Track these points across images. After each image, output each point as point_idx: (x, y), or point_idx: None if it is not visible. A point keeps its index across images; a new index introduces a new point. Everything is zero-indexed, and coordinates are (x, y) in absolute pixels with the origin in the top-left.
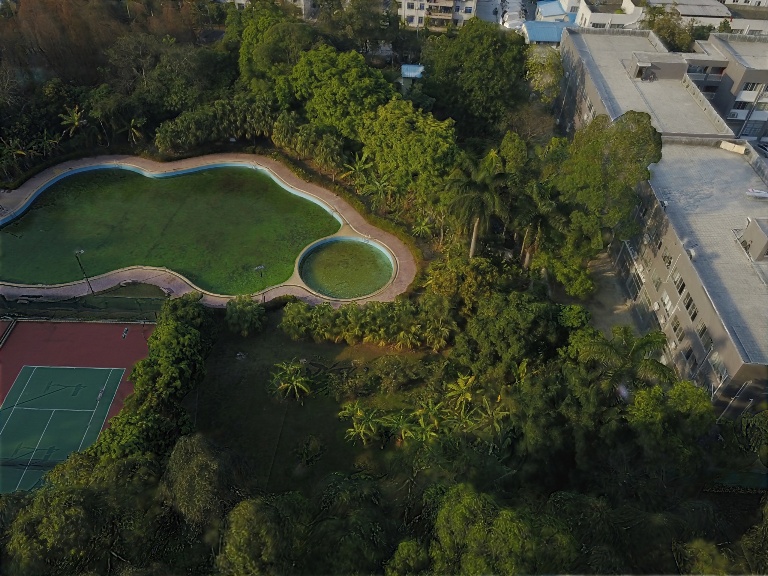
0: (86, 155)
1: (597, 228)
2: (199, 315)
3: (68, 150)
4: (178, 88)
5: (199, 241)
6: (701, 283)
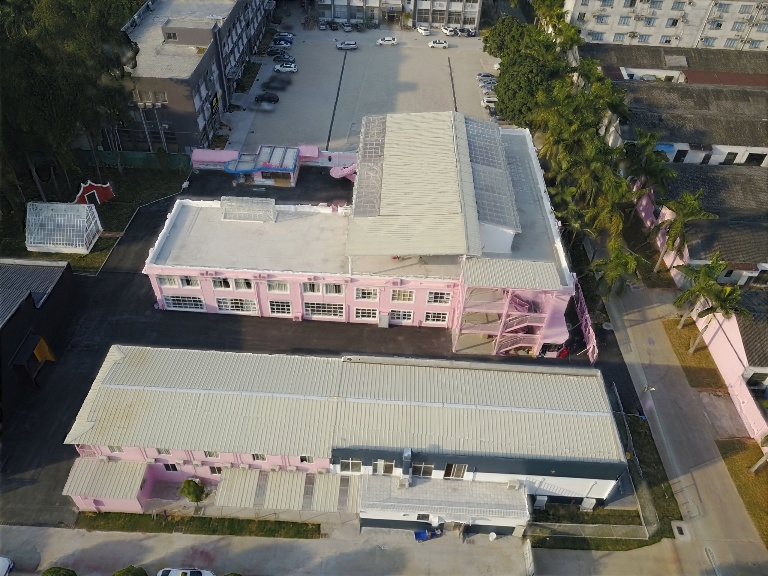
0: None
1: None
2: None
3: None
4: None
5: None
6: None
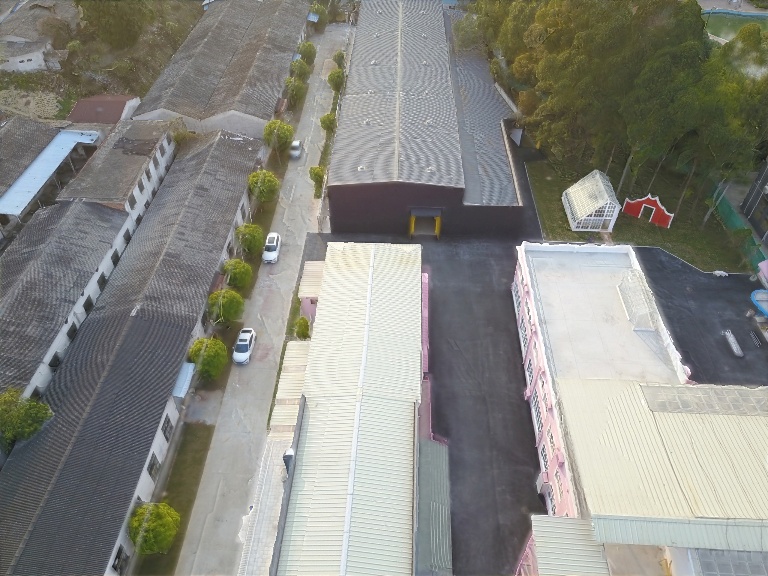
0: None
1: None
2: None
3: None
4: None
5: None
6: None
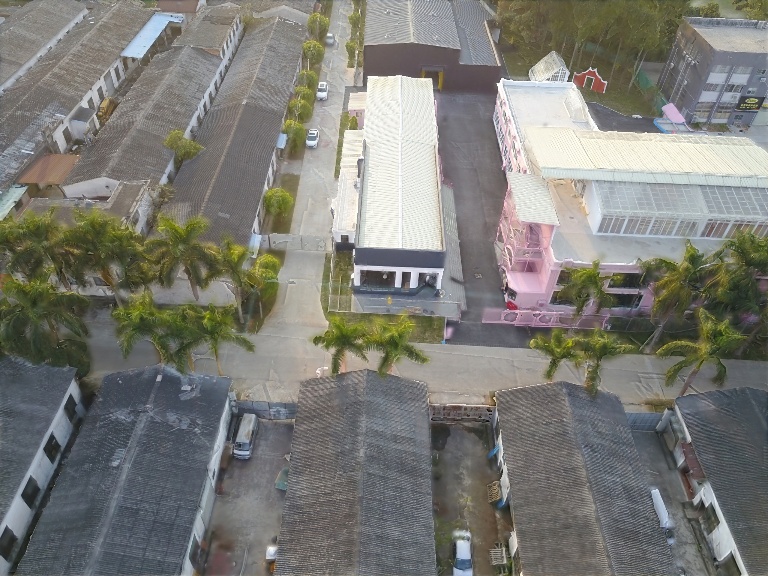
0: None
1: (754, 1)
2: None
3: None
4: None
5: (696, 2)
6: None
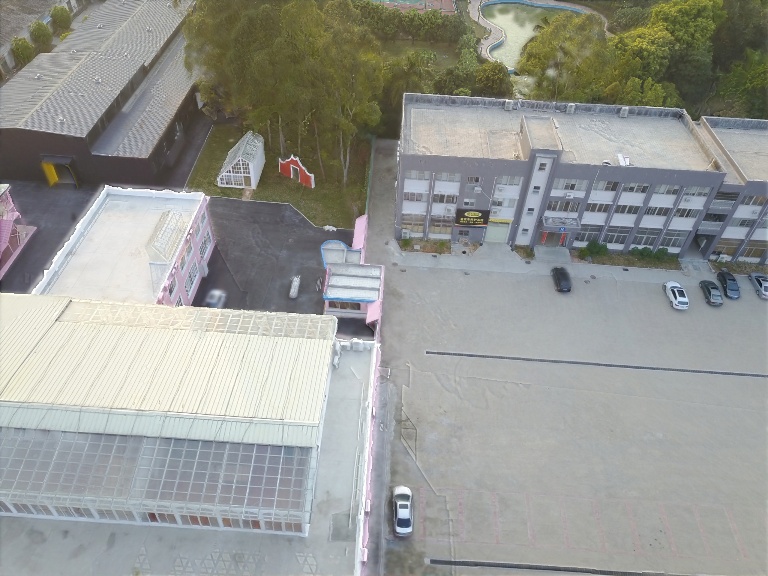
0: (598, 10)
1: None
2: (451, 22)
3: (596, 3)
4: (669, 3)
5: None
6: (476, 97)
